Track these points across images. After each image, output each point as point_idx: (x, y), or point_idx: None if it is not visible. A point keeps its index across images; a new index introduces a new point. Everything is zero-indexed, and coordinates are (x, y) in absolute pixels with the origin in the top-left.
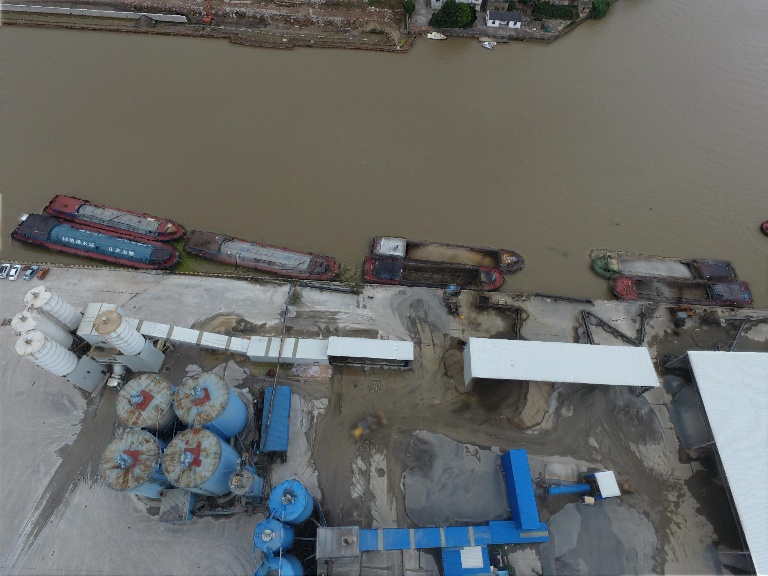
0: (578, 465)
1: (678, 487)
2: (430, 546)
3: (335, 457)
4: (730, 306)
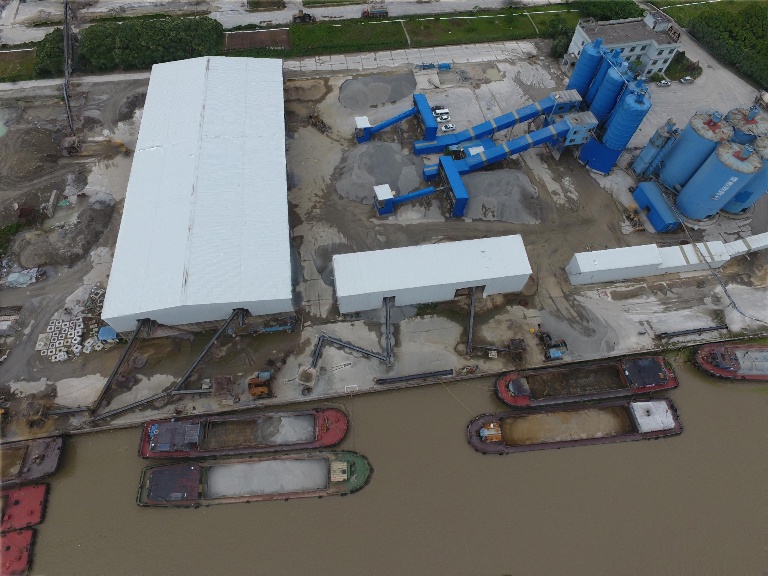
0: (397, 220)
1: (310, 218)
2: (514, 140)
3: (594, 197)
4: (181, 418)
